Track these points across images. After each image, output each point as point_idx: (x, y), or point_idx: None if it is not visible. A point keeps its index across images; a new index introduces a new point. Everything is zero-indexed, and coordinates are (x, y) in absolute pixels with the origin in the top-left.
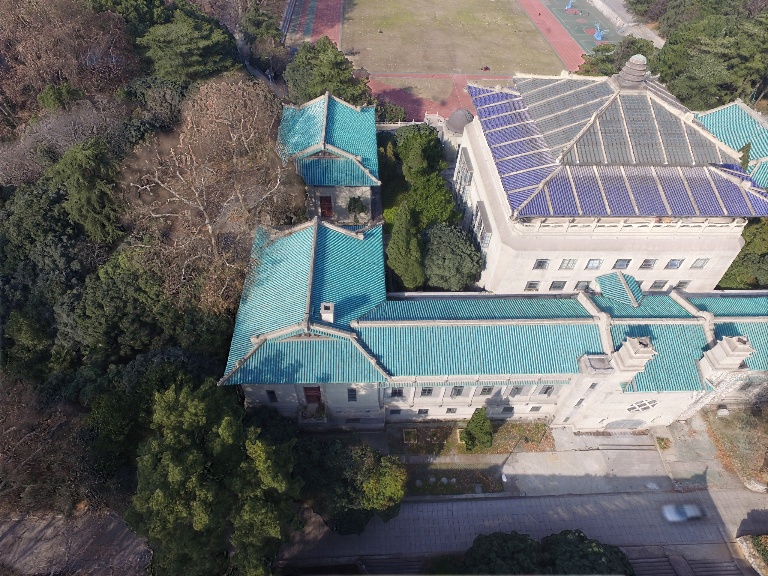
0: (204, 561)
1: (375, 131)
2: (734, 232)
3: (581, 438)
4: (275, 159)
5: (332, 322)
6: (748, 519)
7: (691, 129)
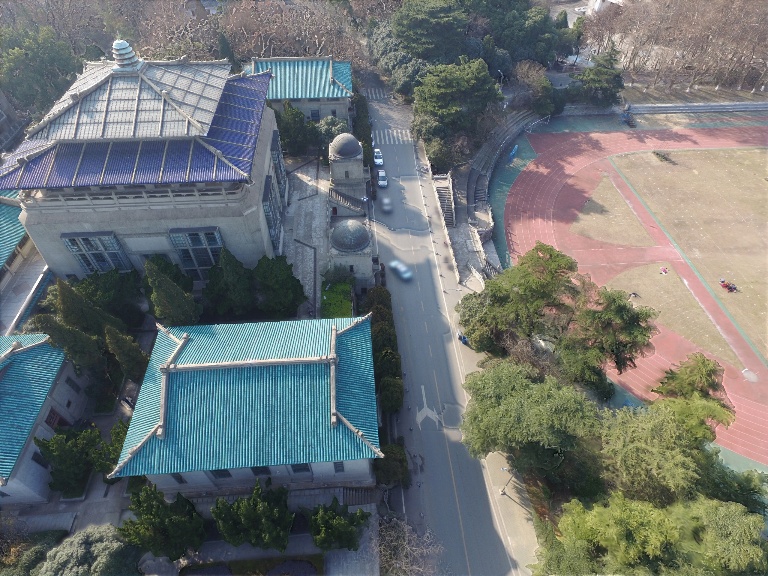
0: None
1: (311, 97)
2: None
3: None
4: None
5: None
6: None
7: None
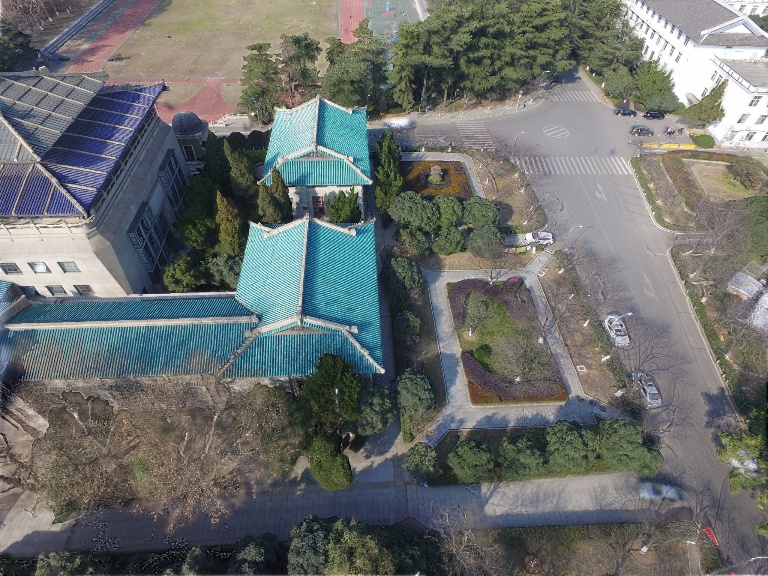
0: None
1: None
2: (77, 233)
3: None
4: None
5: None
6: (20, 542)
7: (2, 125)
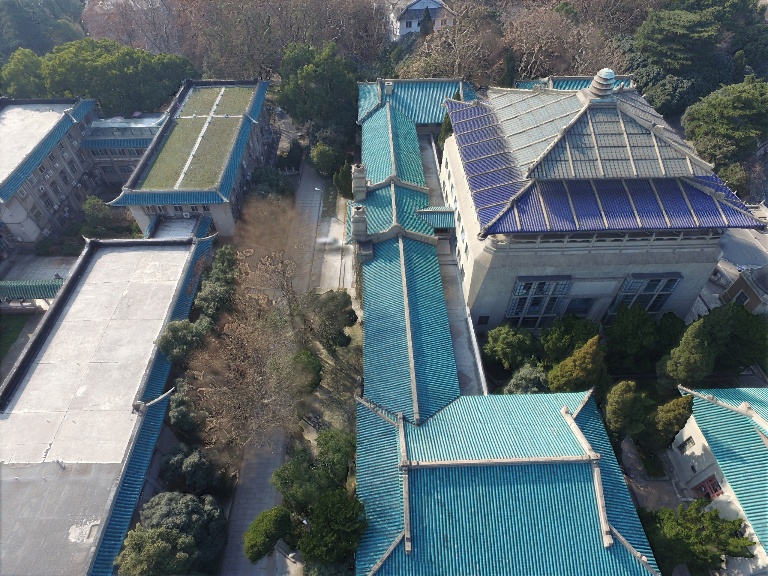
0: (282, 82)
1: None
2: (485, 240)
3: (351, 254)
4: (508, 56)
5: (386, 93)
6: None
7: (553, 140)
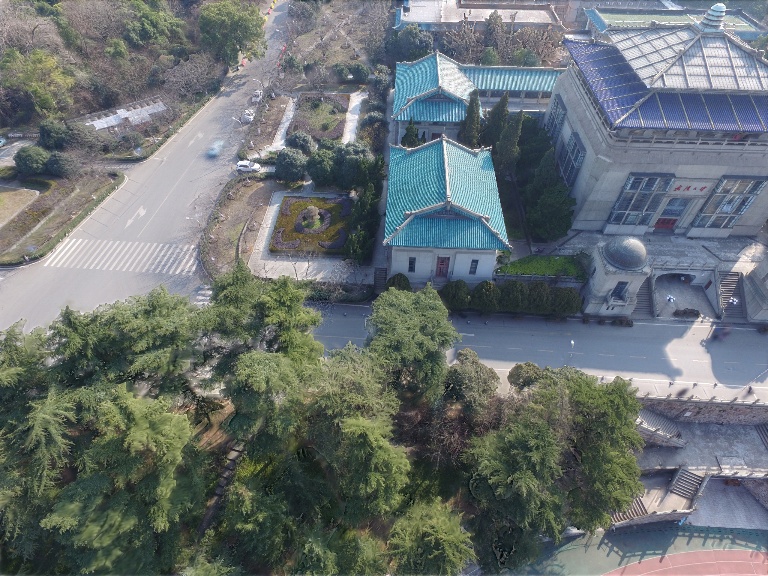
0: None
1: None
2: None
3: None
4: None
5: None
6: None
7: None
